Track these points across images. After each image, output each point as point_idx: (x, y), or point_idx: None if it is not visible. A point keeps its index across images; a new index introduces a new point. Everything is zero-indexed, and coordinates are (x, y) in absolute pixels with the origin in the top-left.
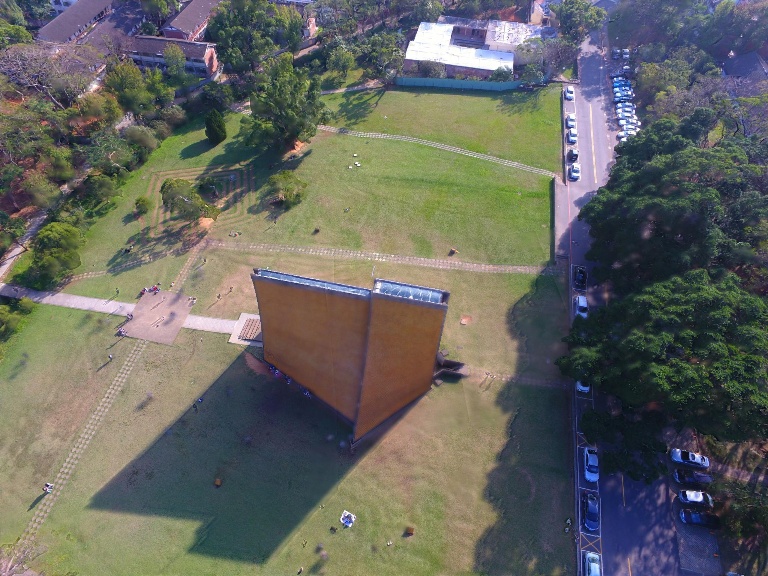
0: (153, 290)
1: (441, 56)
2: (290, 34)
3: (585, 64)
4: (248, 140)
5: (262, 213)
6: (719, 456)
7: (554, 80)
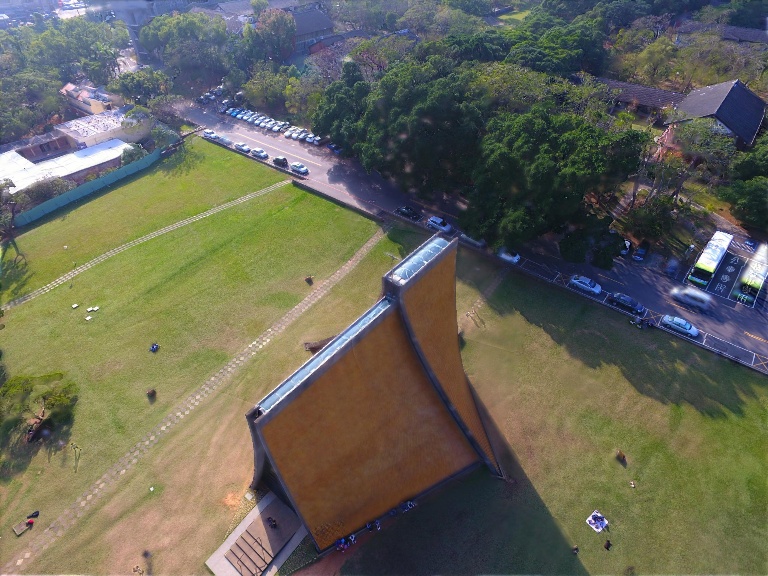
0: None
1: None
2: None
3: (189, 116)
4: None
5: (33, 461)
6: None
7: (184, 135)
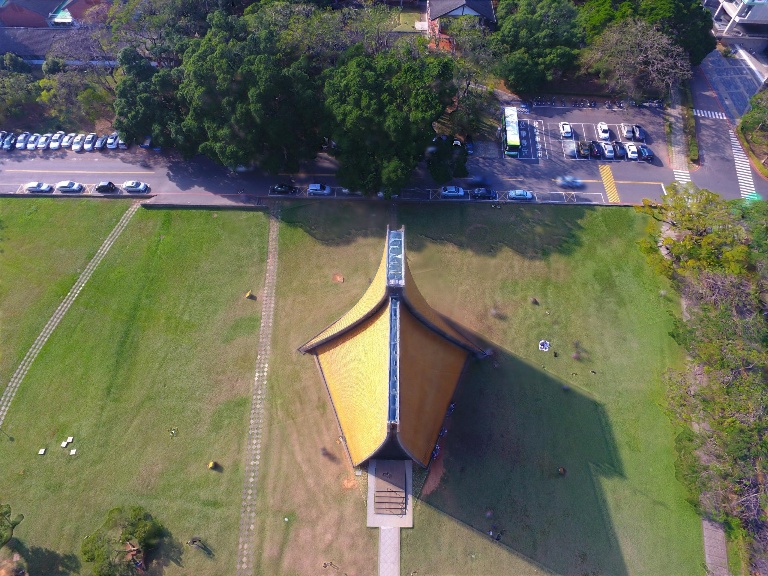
0: None
1: None
2: None
3: None
4: None
5: None
6: None
7: None
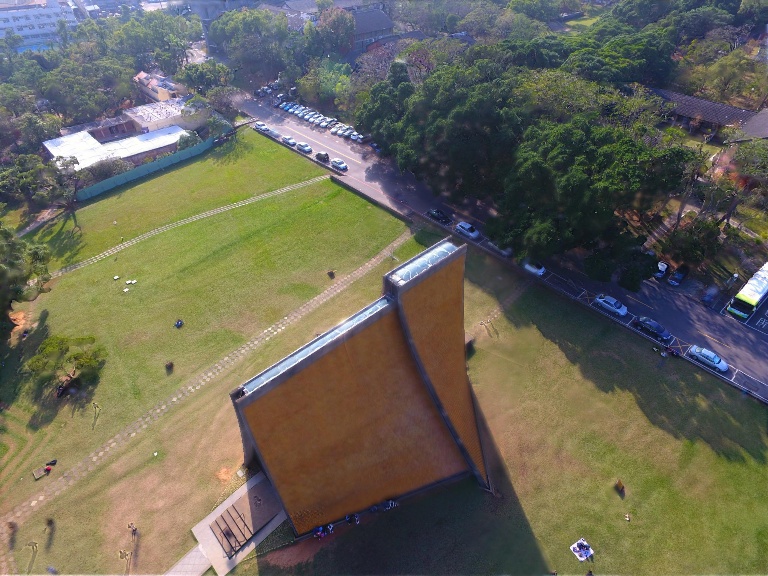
0: None
1: None
2: None
3: (245, 108)
4: None
5: (59, 415)
6: None
7: (237, 126)
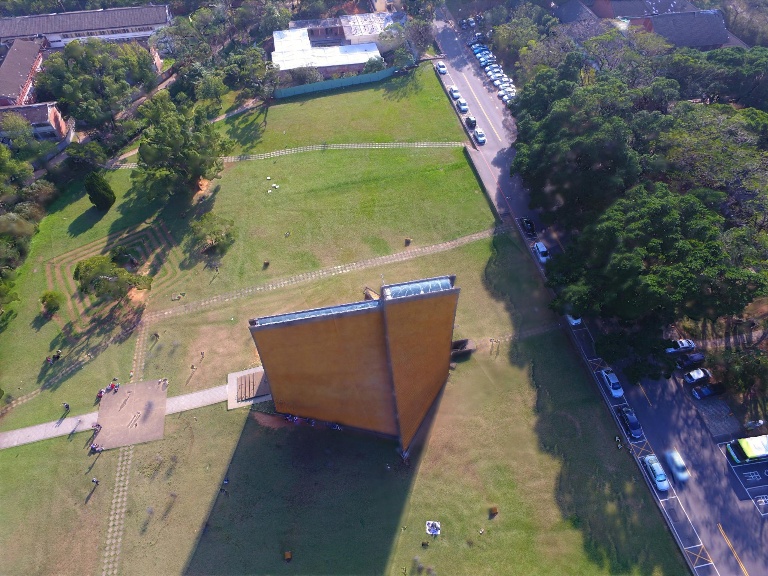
0: (111, 389)
1: (309, 60)
2: (142, 72)
3: (441, 39)
4: (149, 194)
5: (198, 265)
6: (697, 335)
7: (422, 59)
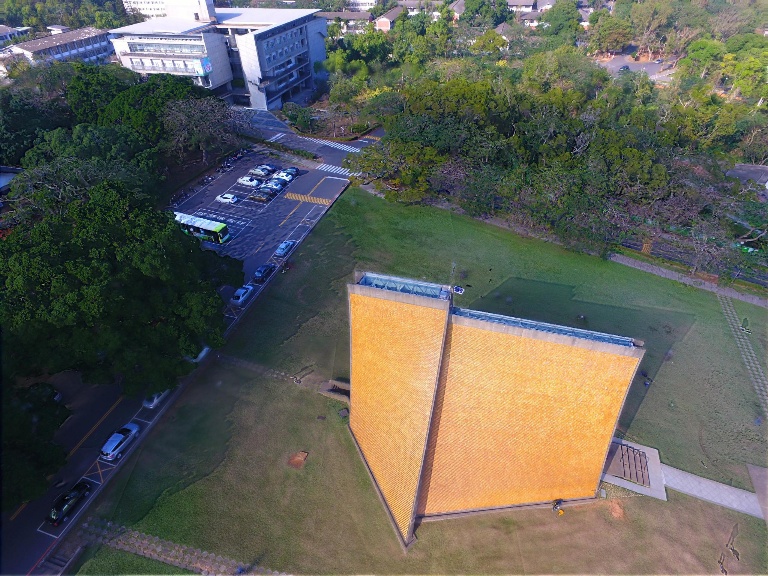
0: None
1: None
2: None
3: None
4: None
5: None
6: None
7: None
